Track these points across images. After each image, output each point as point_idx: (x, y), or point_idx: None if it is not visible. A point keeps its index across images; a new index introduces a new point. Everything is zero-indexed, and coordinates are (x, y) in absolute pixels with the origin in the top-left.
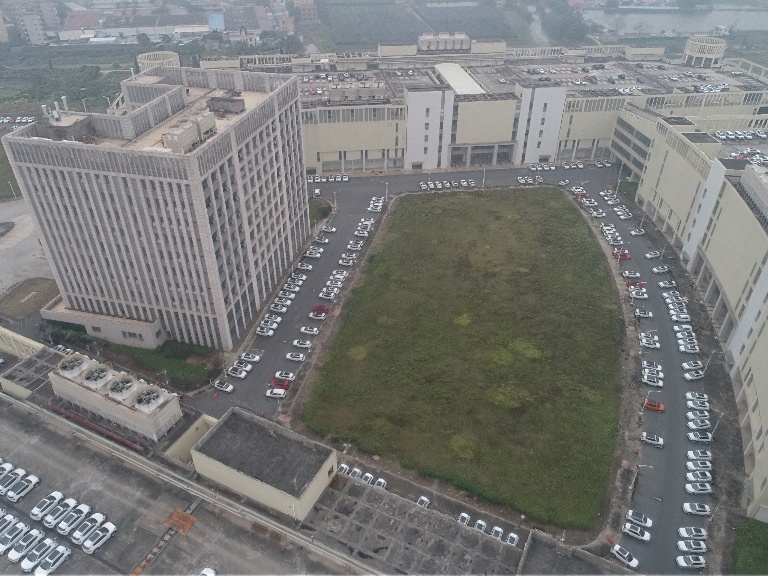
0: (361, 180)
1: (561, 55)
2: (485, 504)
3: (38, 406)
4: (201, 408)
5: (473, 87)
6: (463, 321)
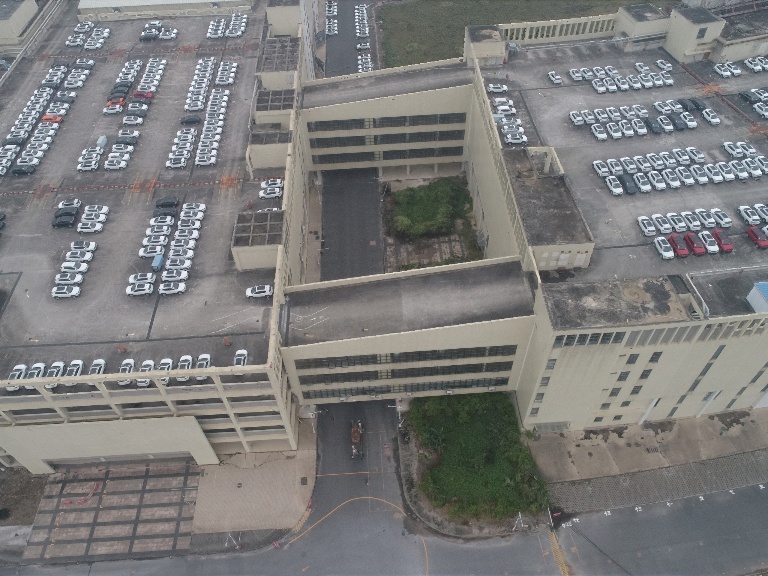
0: None
1: None
2: (383, 62)
3: None
4: None
5: None
6: None
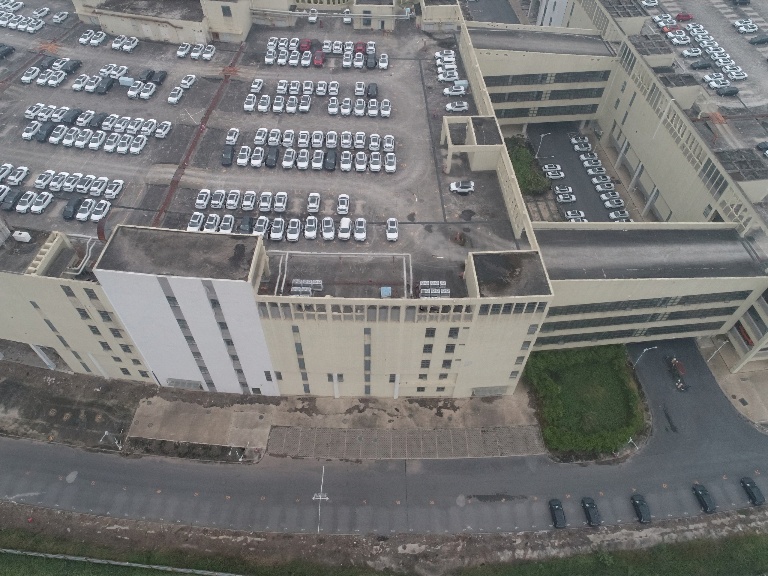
0: None
1: None
2: None
3: None
4: None
5: None
6: None
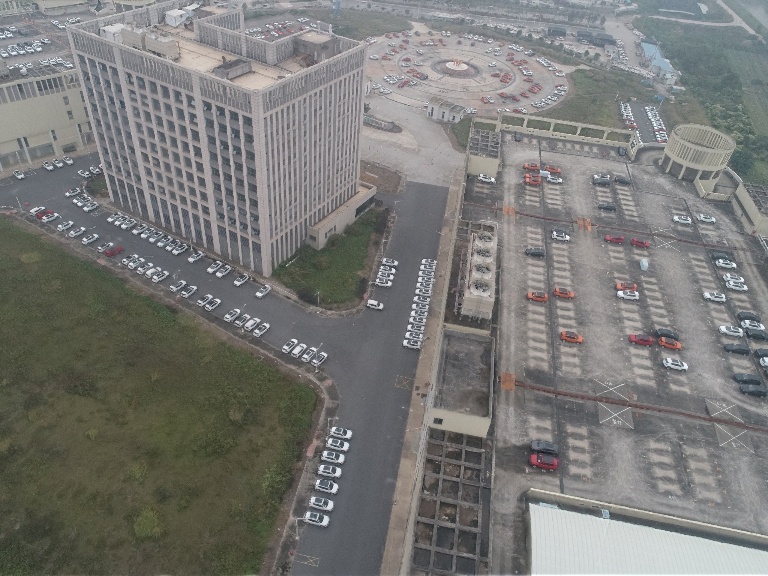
0: (405, 364)
1: None
2: None
3: (8, 69)
4: (66, 185)
5: (618, 572)
6: None
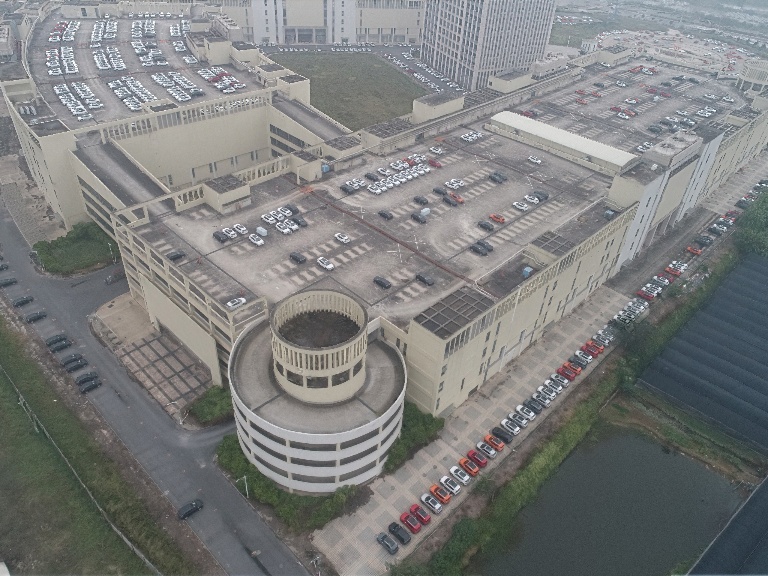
0: None
1: (553, 230)
2: None
3: None
4: None
5: (523, 123)
6: (352, 78)
